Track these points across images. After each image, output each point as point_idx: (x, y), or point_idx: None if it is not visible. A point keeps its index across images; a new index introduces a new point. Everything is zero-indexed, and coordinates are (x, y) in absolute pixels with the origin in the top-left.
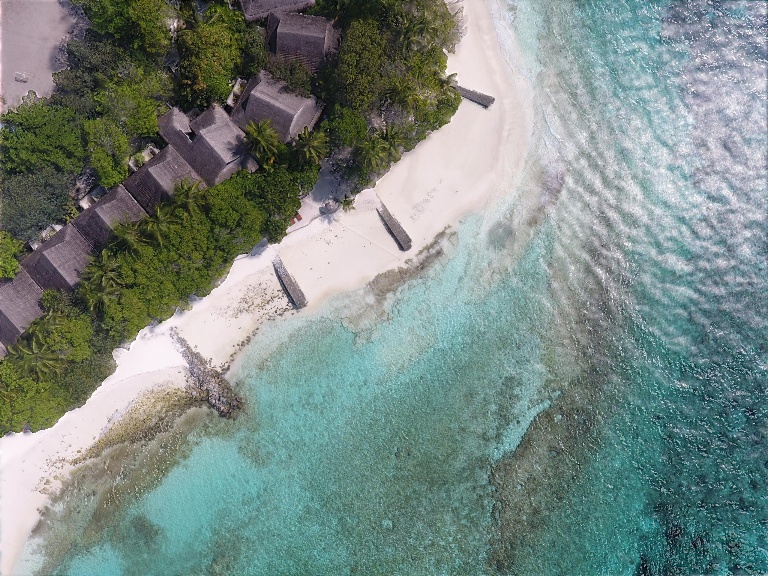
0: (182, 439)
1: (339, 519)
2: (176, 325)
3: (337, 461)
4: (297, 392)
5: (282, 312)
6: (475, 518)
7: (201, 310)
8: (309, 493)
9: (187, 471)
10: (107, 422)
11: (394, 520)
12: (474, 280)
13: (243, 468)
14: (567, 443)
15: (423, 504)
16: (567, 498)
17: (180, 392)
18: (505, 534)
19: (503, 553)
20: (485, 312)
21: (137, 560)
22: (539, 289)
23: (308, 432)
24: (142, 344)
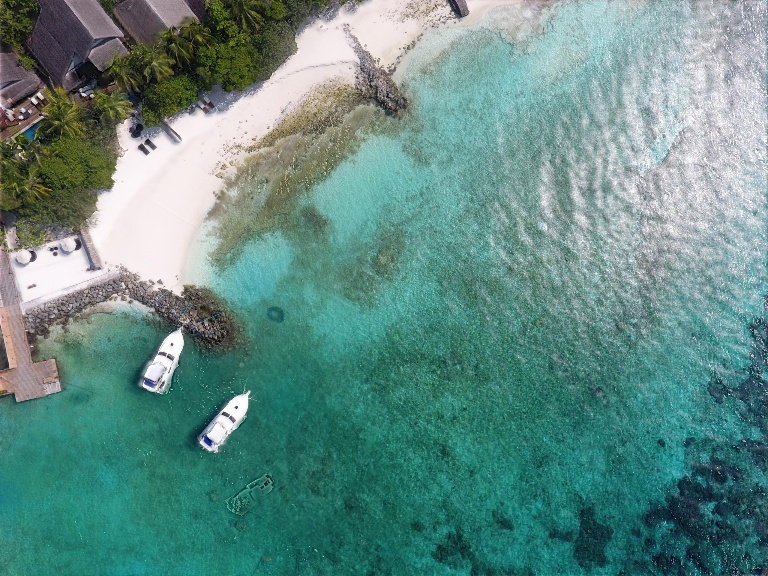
0: (351, 134)
1: (497, 219)
2: (348, 22)
3: (495, 164)
4: (458, 97)
5: (445, 20)
6: (625, 224)
7: (371, 10)
8: (469, 193)
9: (354, 166)
10: (281, 113)
11: (549, 222)
12: (623, 1)
13: (407, 166)
14: (710, 158)
15: (576, 208)
16: (710, 210)
17: (350, 89)
18: (653, 240)
19: (651, 258)
20: (633, 32)
21: (306, 248)
22: (683, 14)
23: (468, 135)
24: (318, 35)
